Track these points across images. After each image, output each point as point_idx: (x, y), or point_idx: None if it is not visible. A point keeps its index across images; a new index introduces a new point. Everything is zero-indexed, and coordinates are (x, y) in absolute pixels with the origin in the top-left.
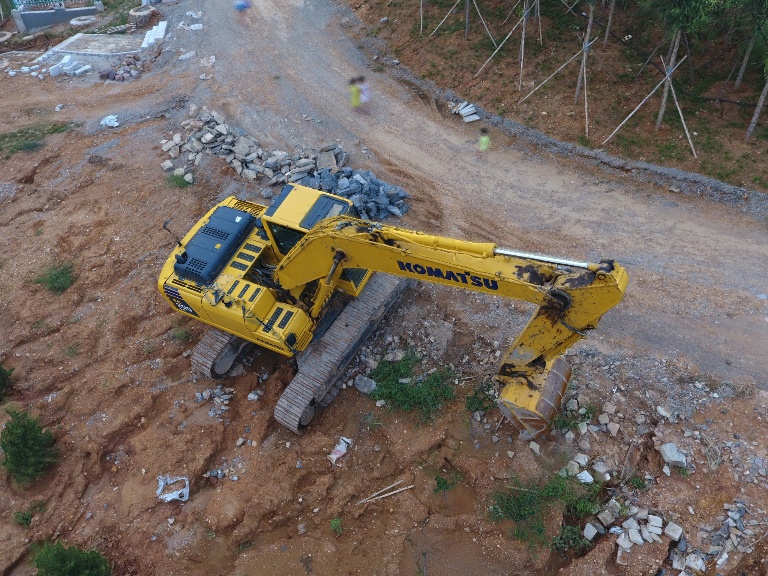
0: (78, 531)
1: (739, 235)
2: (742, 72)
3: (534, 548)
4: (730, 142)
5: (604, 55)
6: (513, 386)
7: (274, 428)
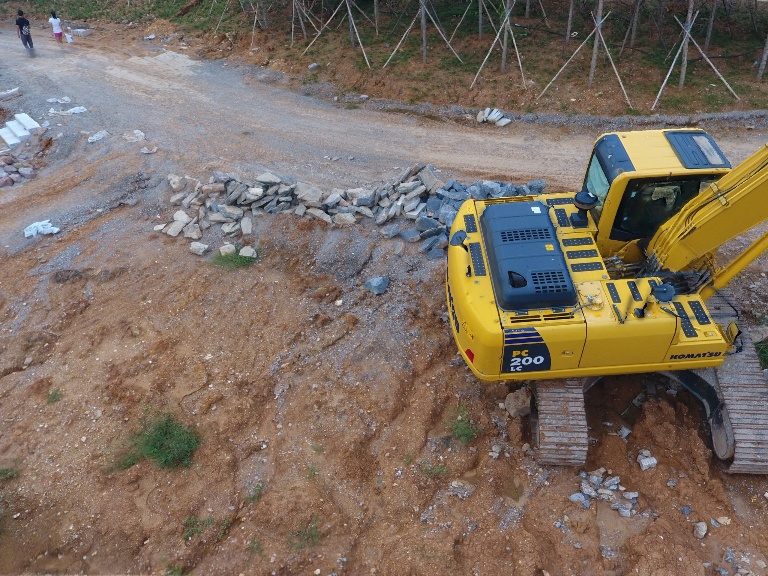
0: None
1: None
2: (710, 32)
3: None
4: (751, 83)
5: (576, 47)
6: None
7: None
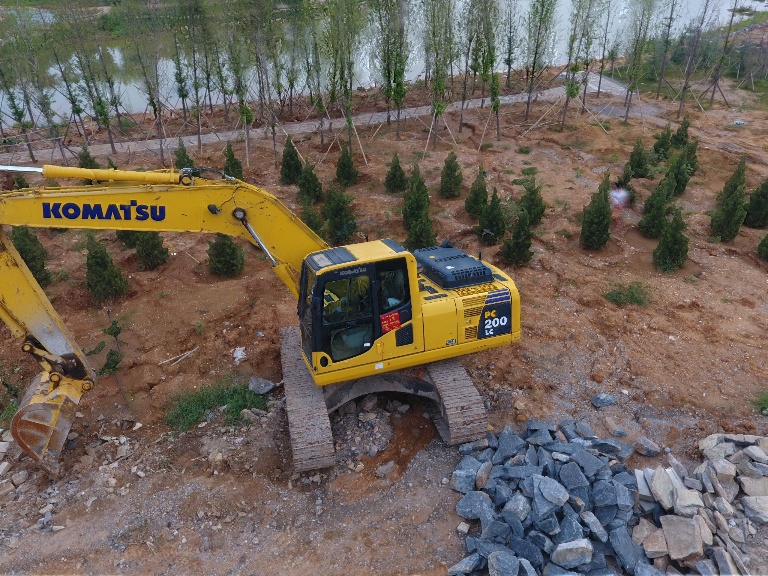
0: None
1: None
2: None
3: None
4: None
5: None
6: None
7: None
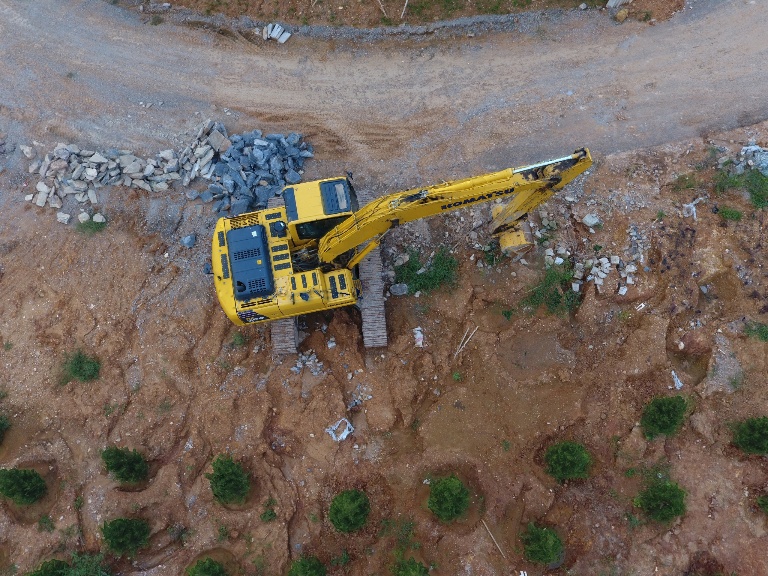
0: (308, 495)
1: (530, 53)
2: None
3: (560, 314)
4: None
5: None
6: (507, 236)
7: (363, 354)
